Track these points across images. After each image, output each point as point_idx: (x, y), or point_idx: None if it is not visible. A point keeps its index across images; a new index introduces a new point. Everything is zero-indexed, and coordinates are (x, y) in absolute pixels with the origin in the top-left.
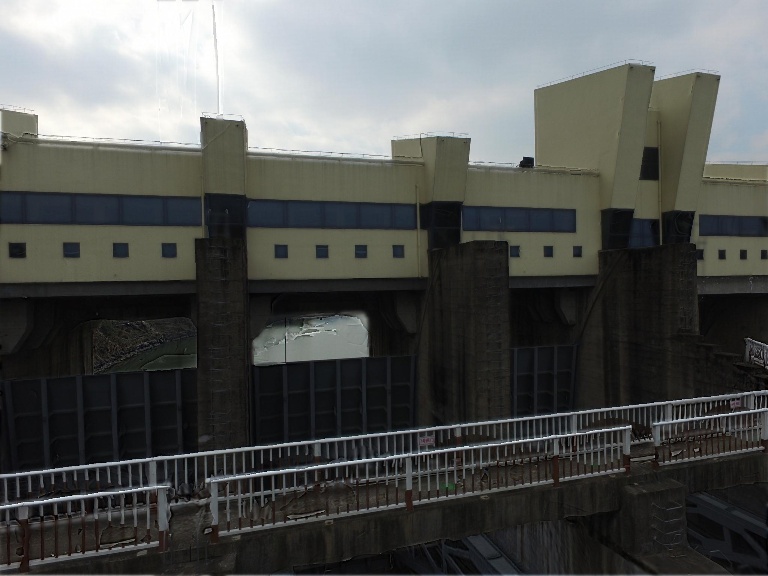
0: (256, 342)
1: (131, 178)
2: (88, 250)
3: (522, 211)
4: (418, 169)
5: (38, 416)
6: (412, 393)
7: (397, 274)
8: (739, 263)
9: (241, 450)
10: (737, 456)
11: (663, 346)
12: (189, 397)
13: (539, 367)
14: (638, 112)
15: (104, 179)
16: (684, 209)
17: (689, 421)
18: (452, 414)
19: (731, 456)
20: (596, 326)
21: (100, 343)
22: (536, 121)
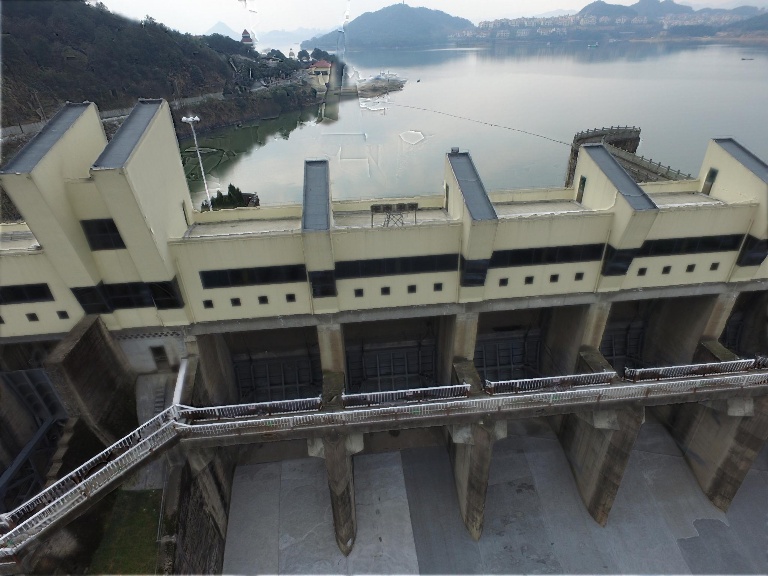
0: (262, 135)
1: None
2: None
3: None
4: None
5: None
6: None
7: None
8: (259, 307)
9: None
10: None
11: None
12: None
13: None
14: (42, 214)
15: None
16: (155, 280)
17: None
18: None
19: None
20: None
21: None
22: None
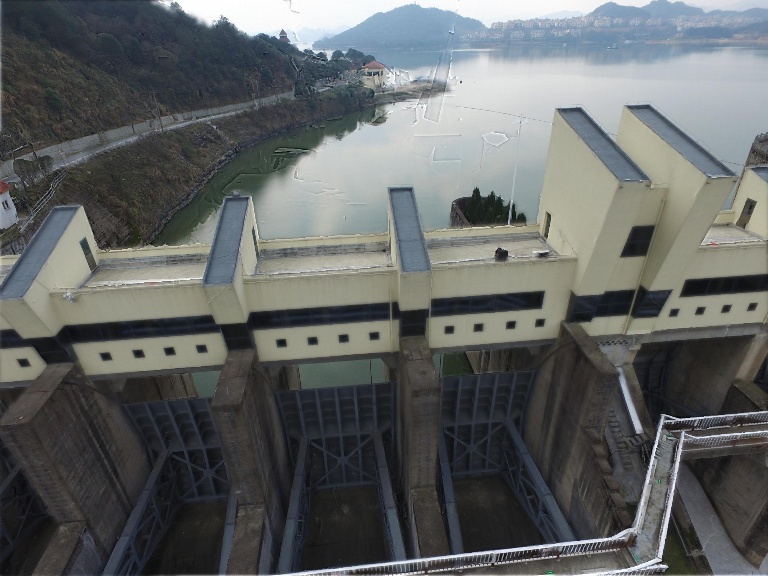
0: (327, 135)
1: (164, 308)
2: (149, 353)
3: (490, 297)
4: (391, 276)
5: None
6: (393, 402)
7: (374, 351)
8: (718, 316)
9: None
10: None
11: (576, 426)
12: None
13: (501, 382)
14: (623, 222)
15: (146, 310)
16: (660, 289)
17: None
18: None
19: None
20: (548, 371)
21: (183, 173)
22: (550, 147)
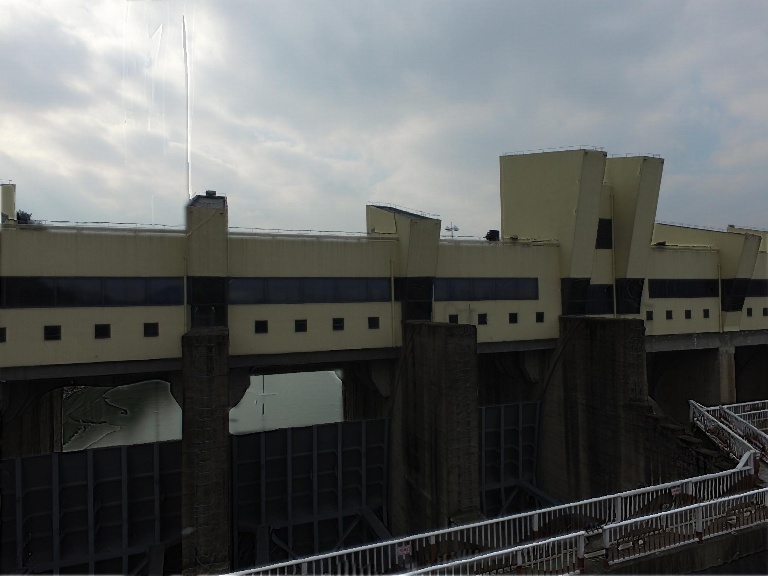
0: None
1: (114, 260)
2: (69, 332)
3: (489, 281)
4: (393, 244)
5: (11, 496)
6: (386, 454)
7: (372, 345)
8: (684, 322)
9: (233, 575)
10: (676, 549)
11: (617, 413)
12: (167, 469)
13: (505, 423)
14: (593, 192)
15: (87, 262)
16: (635, 276)
17: (634, 521)
18: (424, 483)
19: (671, 550)
20: (557, 386)
21: None
22: (502, 185)
